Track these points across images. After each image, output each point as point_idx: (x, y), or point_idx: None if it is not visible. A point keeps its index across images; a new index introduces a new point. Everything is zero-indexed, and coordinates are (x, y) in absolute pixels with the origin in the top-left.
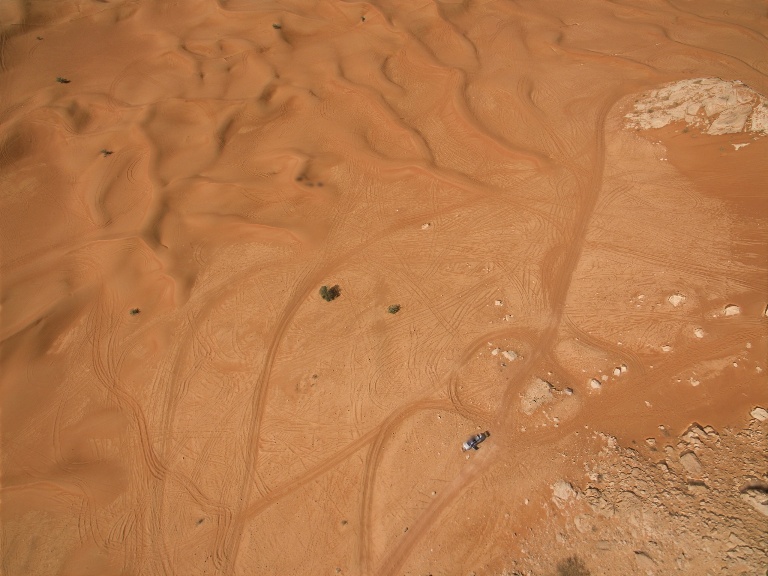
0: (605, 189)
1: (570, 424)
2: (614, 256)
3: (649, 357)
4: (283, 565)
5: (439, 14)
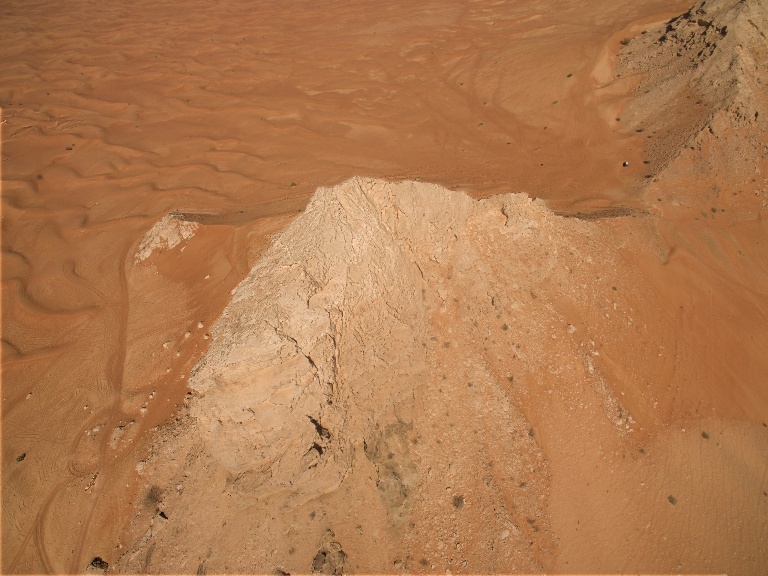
0: (131, 307)
1: (138, 436)
2: (141, 342)
3: (164, 379)
4: None
5: None
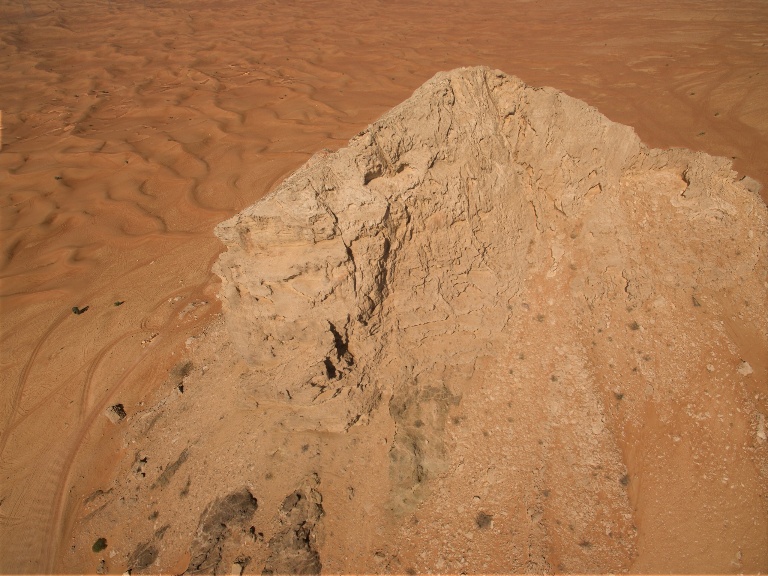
0: None
1: (203, 316)
2: None
3: None
4: (33, 438)
5: (183, 150)
